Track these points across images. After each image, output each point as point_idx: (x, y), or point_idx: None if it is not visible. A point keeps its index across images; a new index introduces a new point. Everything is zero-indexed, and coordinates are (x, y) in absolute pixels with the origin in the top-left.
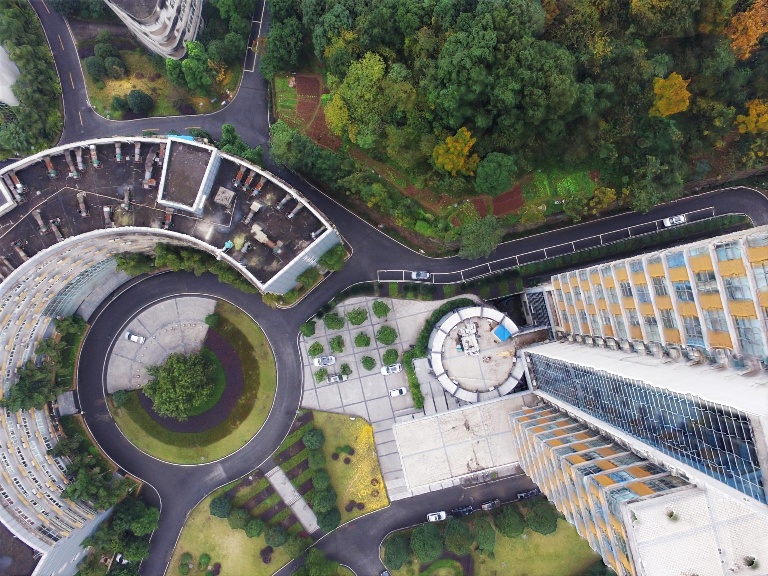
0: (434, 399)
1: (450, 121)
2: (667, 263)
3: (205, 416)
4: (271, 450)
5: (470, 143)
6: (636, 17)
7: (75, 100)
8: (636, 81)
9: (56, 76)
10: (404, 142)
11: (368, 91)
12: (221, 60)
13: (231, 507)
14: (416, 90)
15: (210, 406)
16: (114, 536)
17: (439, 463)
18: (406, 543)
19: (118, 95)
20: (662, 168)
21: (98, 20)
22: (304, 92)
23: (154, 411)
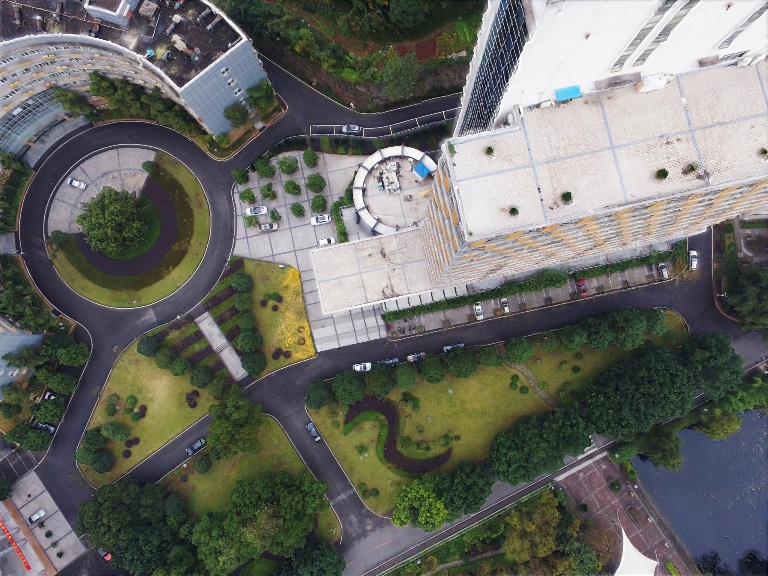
0: None
1: None
2: None
3: (139, 260)
4: (202, 296)
5: None
6: None
7: None
8: None
9: None
10: None
11: None
12: None
13: (158, 347)
14: None
15: (144, 250)
16: (39, 361)
17: (355, 289)
18: (329, 387)
19: None
20: None
21: None
22: None
23: (86, 241)
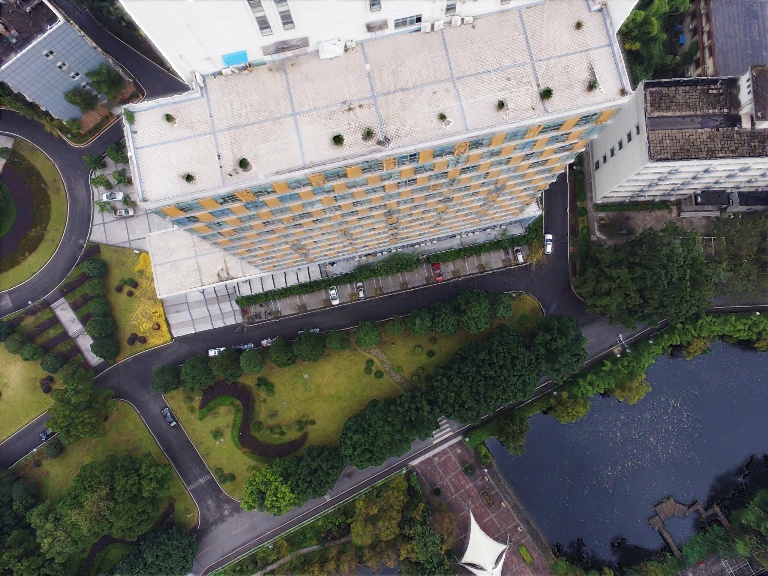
0: None
1: None
2: None
3: None
4: (58, 282)
5: None
6: None
7: None
8: None
9: None
10: None
11: None
12: None
13: (10, 332)
14: None
15: None
16: None
17: (190, 272)
18: (178, 372)
19: None
20: None
21: None
22: None
23: None
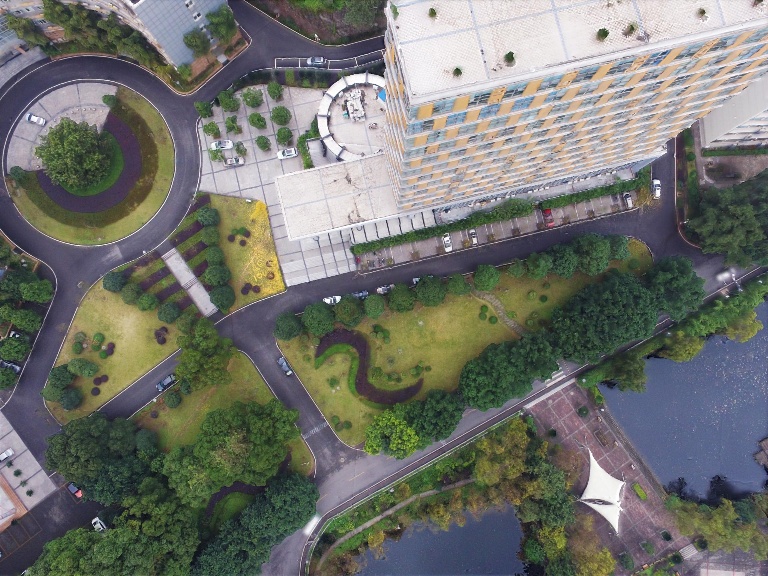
0: None
1: None
2: None
3: (102, 196)
4: (168, 232)
5: None
6: None
7: None
8: None
9: None
10: None
11: None
12: None
13: (125, 283)
14: None
15: (107, 186)
16: (1, 296)
17: (321, 215)
18: (298, 319)
19: None
20: None
21: None
22: None
23: (45, 174)
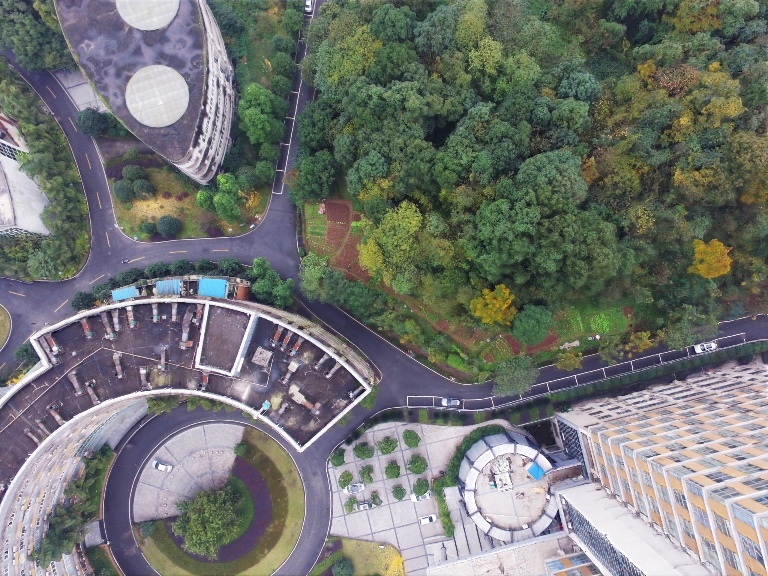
0: (464, 526)
1: (488, 277)
2: (733, 513)
3: (233, 545)
4: None
5: (509, 301)
6: (678, 189)
7: (102, 220)
8: (675, 240)
9: (83, 196)
10: (441, 294)
11: (404, 242)
12: (251, 187)
13: None
14: (453, 243)
15: (238, 535)
16: None
17: None
18: None
19: (146, 216)
20: (699, 316)
21: (125, 137)
22: (334, 218)
23: (183, 549)
